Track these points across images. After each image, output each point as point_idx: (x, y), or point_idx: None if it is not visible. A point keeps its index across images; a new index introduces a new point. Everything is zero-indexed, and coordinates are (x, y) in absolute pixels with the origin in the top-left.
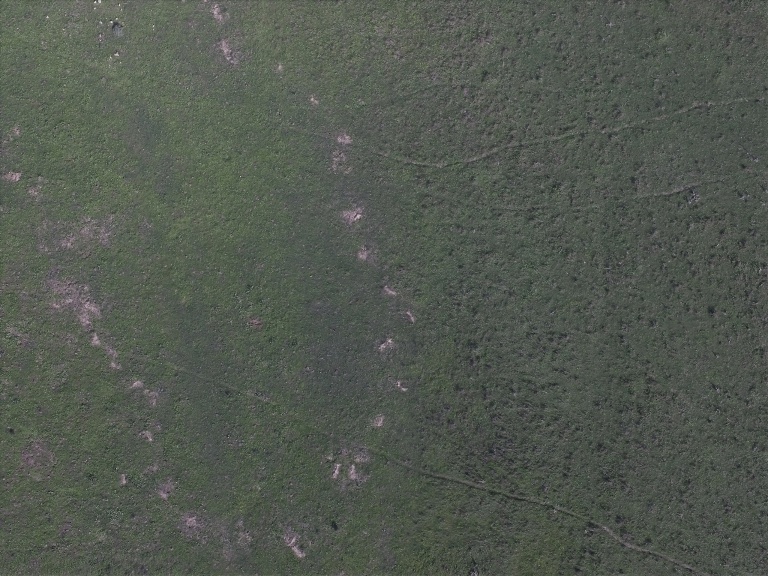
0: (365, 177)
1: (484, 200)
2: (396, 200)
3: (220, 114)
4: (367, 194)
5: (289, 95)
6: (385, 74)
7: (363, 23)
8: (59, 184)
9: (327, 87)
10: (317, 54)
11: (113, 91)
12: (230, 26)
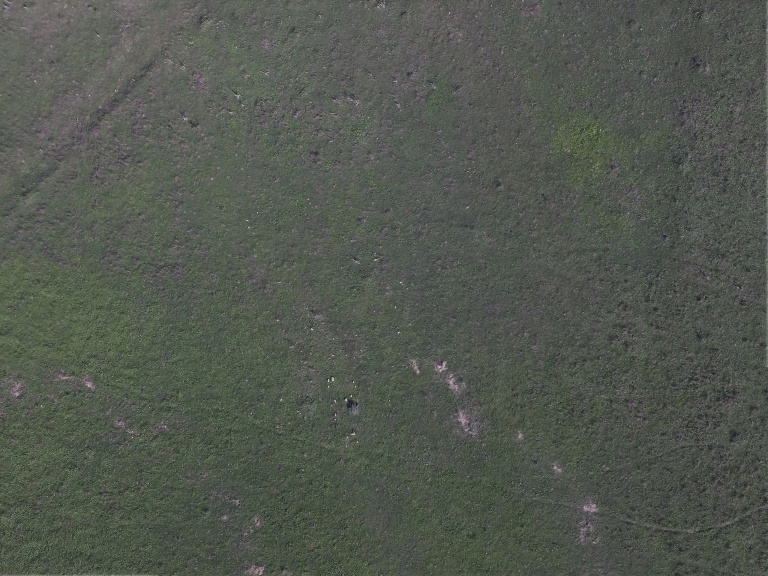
0: (614, 547)
1: (740, 567)
2: (647, 569)
3: (461, 489)
4: (617, 564)
5: (531, 464)
6: (629, 438)
7: (603, 385)
8: (303, 575)
9: (569, 454)
10: (557, 420)
11: (351, 472)
12: (467, 396)
